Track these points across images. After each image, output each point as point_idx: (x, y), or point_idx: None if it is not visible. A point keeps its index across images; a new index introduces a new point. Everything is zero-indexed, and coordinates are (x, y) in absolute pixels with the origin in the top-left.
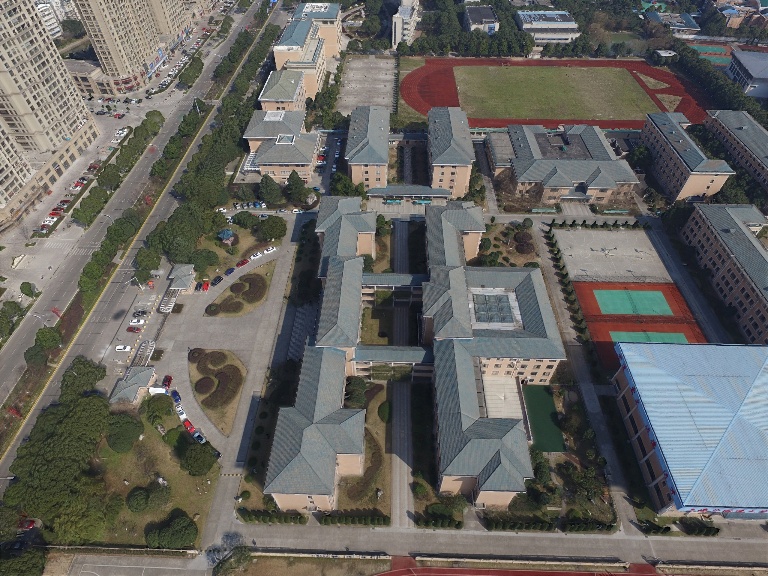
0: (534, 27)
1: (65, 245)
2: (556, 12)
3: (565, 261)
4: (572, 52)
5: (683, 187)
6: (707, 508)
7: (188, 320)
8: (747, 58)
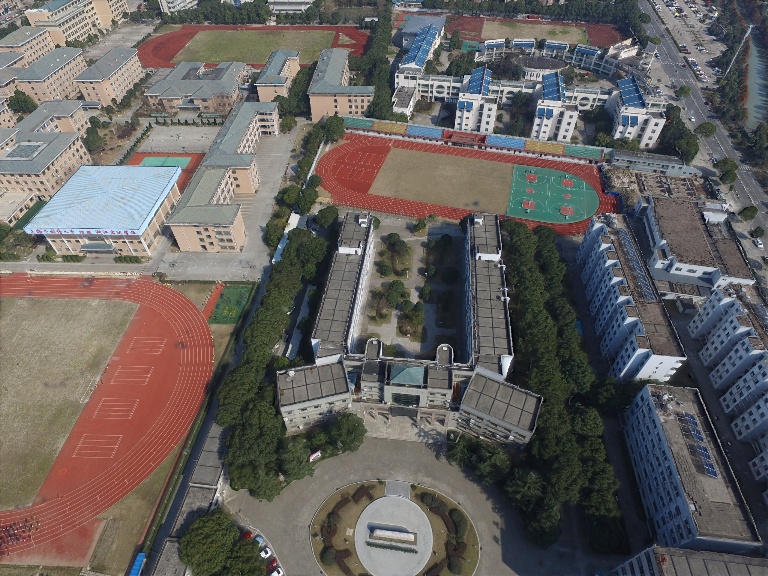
0: (277, 1)
1: None
2: None
3: (144, 142)
4: (299, 20)
5: (259, 97)
6: (38, 229)
7: None
8: (413, 20)
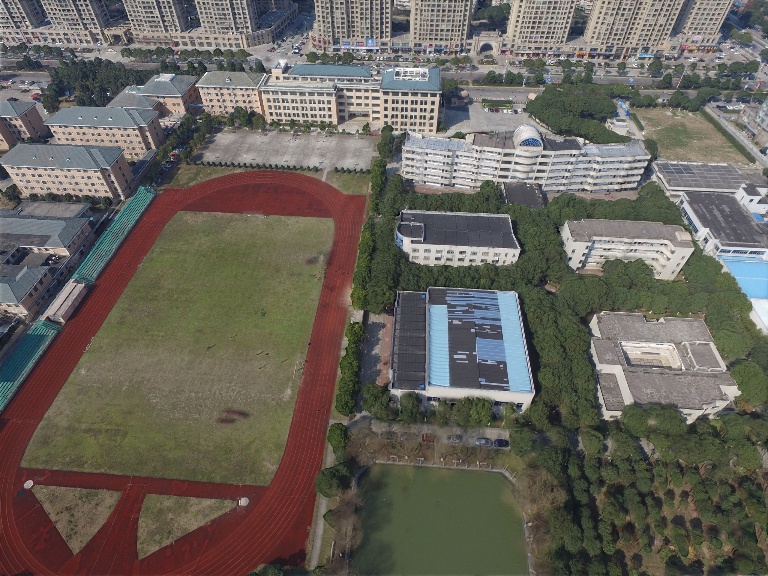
0: None
1: (118, 59)
2: (524, 367)
3: None
4: None
5: None
6: None
7: (13, 95)
8: None
